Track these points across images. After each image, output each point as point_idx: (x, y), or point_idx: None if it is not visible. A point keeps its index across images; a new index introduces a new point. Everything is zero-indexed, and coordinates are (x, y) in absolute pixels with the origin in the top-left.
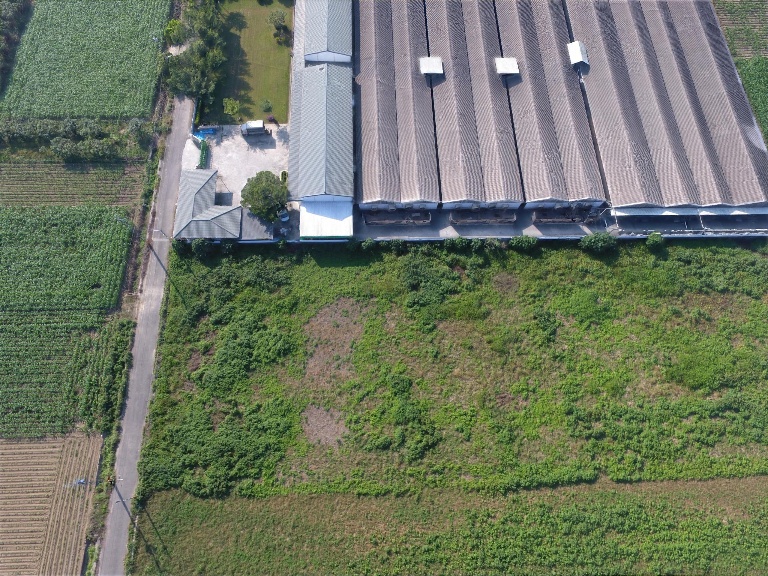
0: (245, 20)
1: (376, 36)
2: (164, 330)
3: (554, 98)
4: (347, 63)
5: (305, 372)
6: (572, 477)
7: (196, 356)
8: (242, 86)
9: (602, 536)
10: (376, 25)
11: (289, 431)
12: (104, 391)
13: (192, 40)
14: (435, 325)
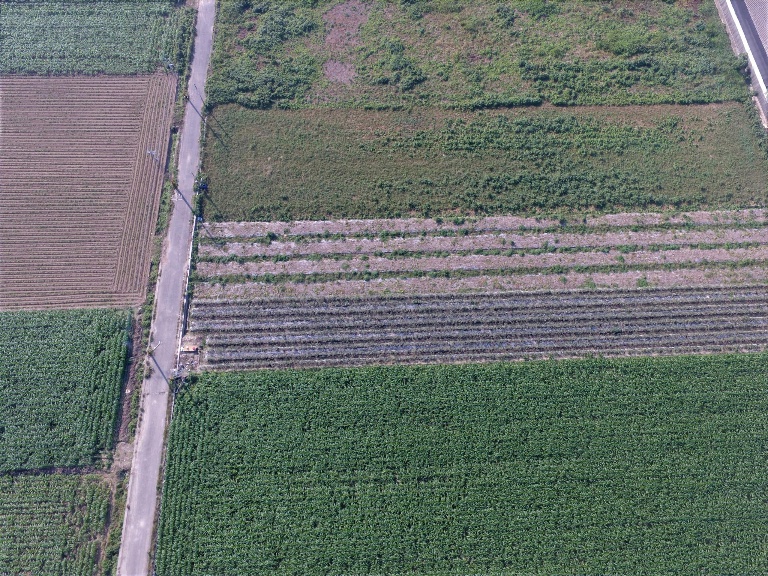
0: None
1: None
2: (219, 15)
3: None
4: None
5: (325, 42)
6: (523, 100)
7: (243, 32)
8: None
9: (544, 134)
10: None
11: (314, 73)
12: (177, 46)
13: None
14: (422, 15)
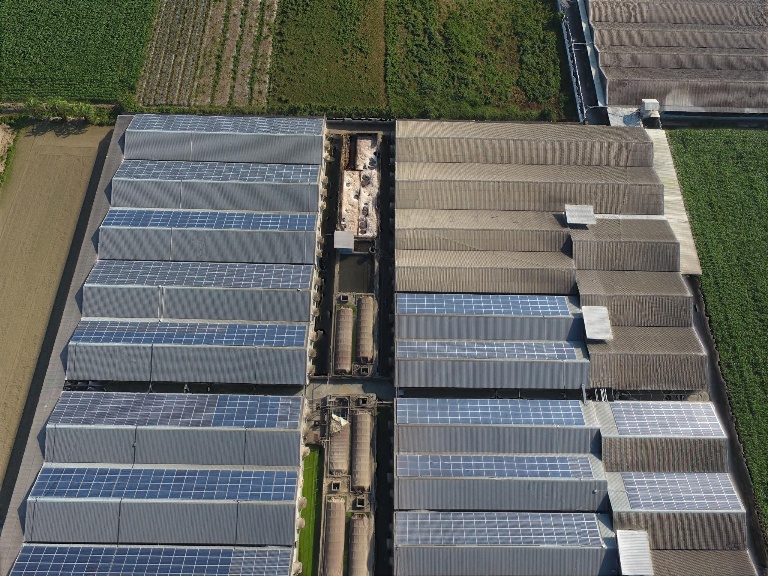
0: None
1: None
2: None
3: None
4: None
5: None
6: None
7: None
8: None
9: None
10: None
11: None
12: None
13: None
14: None
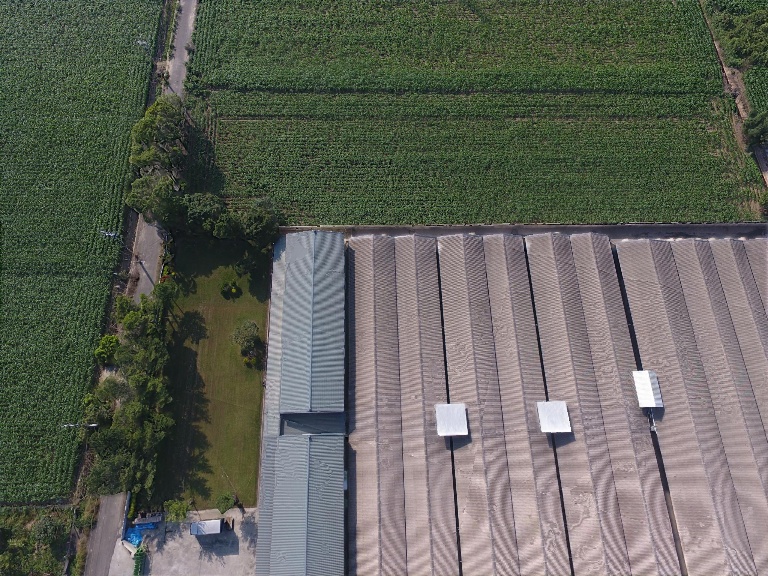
0: (204, 324)
1: (377, 367)
2: None
3: (618, 464)
4: (338, 413)
5: None
6: None
7: None
8: (196, 440)
9: None
10: (377, 347)
11: None
12: None
13: (125, 398)
14: None
